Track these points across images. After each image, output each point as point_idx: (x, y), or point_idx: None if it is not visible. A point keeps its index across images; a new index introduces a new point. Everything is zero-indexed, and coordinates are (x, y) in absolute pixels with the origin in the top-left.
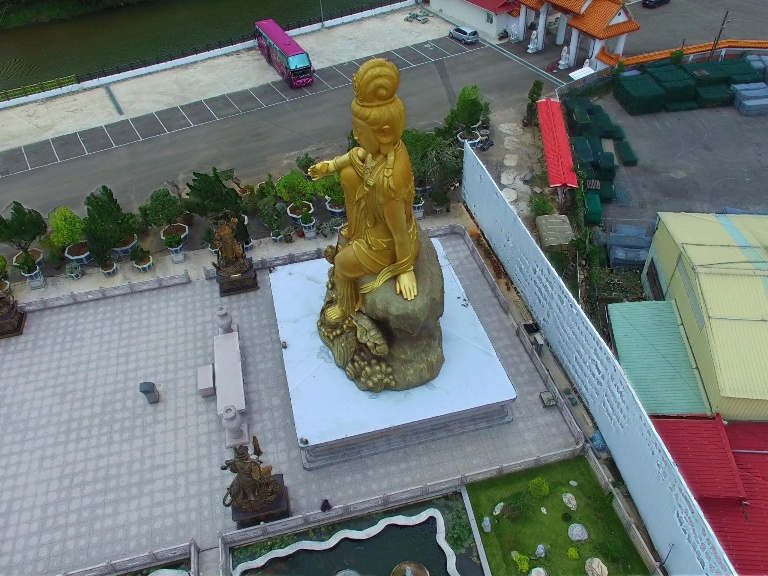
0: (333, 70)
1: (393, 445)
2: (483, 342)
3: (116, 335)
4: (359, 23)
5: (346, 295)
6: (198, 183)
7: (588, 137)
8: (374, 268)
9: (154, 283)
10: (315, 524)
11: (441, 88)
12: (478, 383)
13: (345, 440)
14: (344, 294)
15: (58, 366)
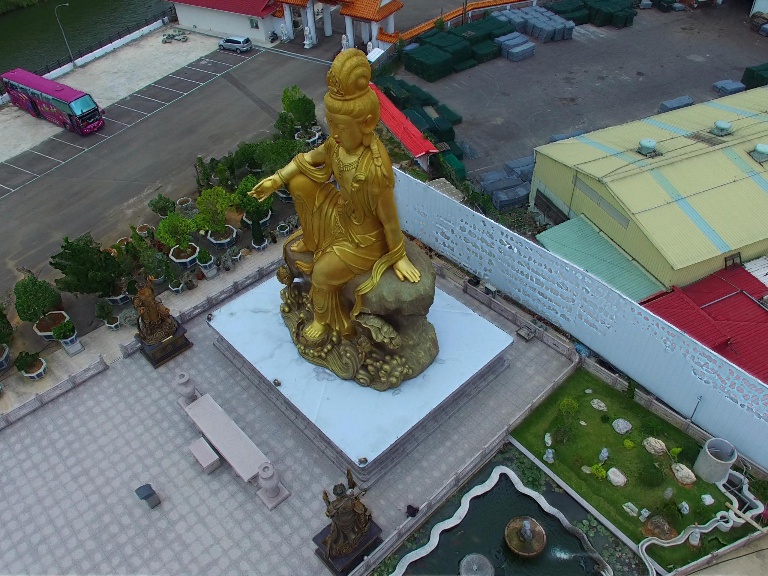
0: (118, 107)
1: (429, 430)
2: (456, 306)
3: (55, 458)
4: (114, 55)
5: (330, 306)
6: (59, 259)
7: (412, 109)
8: (365, 266)
9: (66, 384)
10: (407, 534)
11: (245, 99)
12: (476, 341)
13: (397, 442)
14: (328, 306)
15: (1, 523)
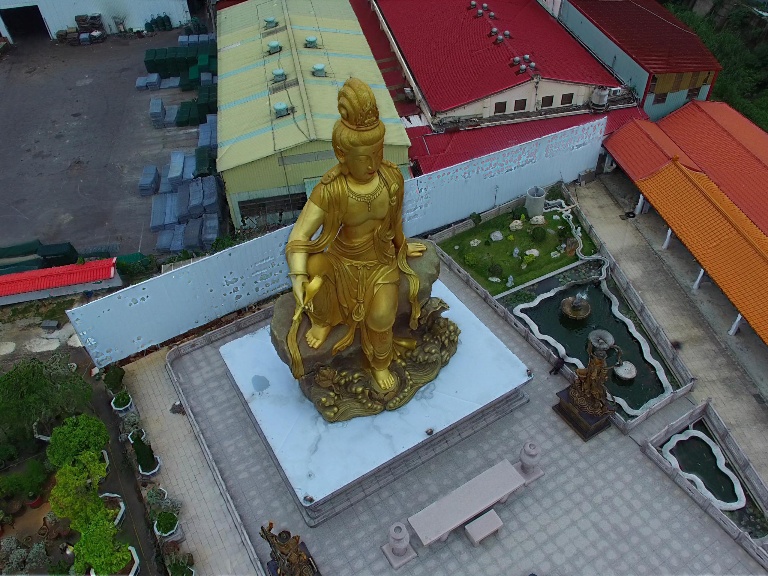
0: None
1: None
2: None
3: None
4: None
5: None
6: None
7: None
8: None
9: None
10: None
11: None
12: None
13: None
14: None
15: None
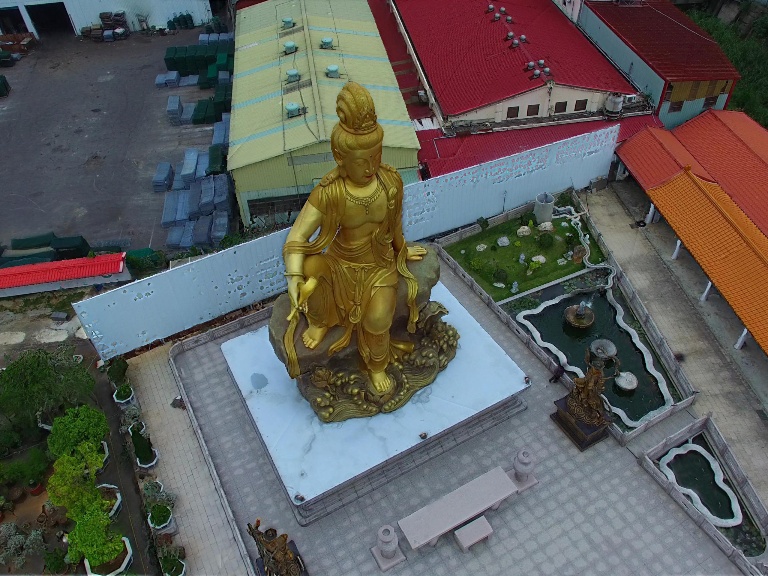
0: None
1: None
2: None
3: None
4: None
5: None
6: None
7: None
8: None
9: None
10: None
11: None
12: None
13: None
14: None
15: None
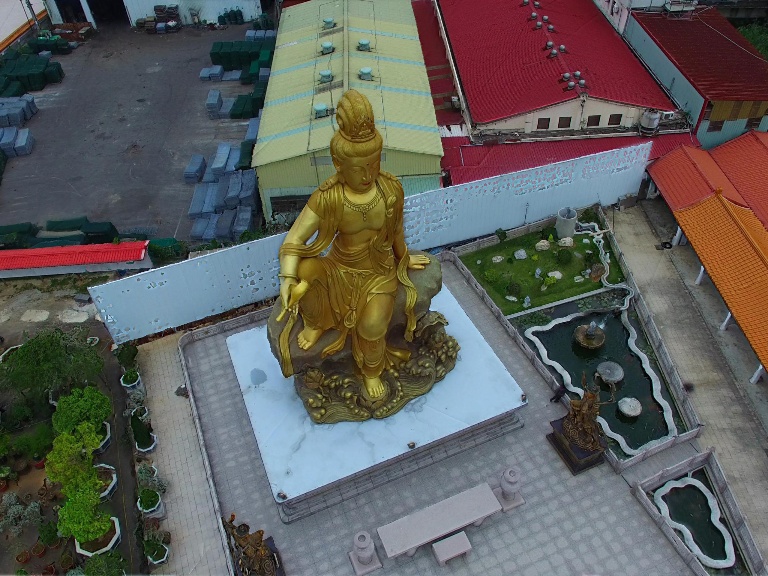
0: None
1: None
2: None
3: None
4: None
5: None
6: None
7: (31, 245)
8: None
9: None
10: None
11: None
12: None
13: None
14: None
15: None
